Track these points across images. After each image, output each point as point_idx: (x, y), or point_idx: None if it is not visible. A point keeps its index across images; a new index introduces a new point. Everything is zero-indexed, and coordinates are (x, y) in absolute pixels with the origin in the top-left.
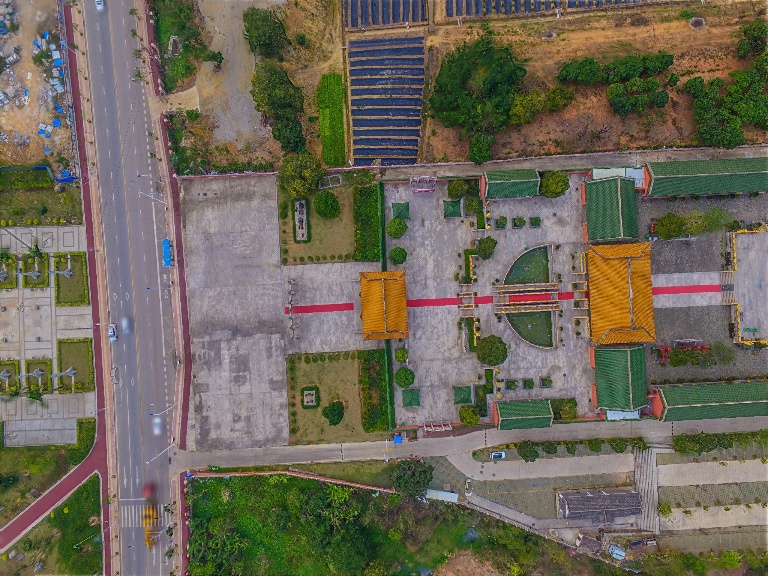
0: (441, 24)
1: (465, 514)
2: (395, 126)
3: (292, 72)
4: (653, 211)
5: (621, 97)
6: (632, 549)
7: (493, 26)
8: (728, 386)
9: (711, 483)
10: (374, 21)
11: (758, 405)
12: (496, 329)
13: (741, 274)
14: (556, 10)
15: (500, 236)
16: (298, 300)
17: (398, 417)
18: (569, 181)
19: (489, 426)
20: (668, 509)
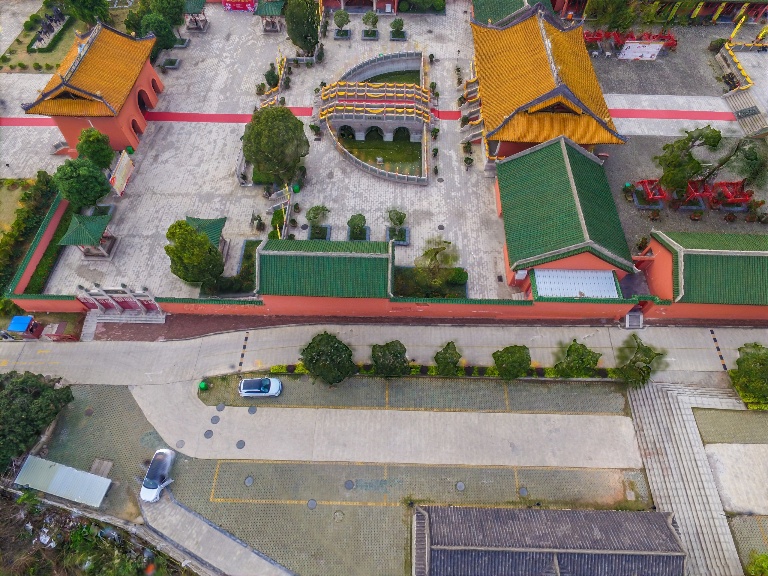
0: None
1: (126, 572)
2: None
3: None
4: None
5: None
6: None
7: None
8: None
9: None
10: None
11: None
12: None
13: (763, 94)
14: None
15: (341, 46)
16: None
17: (54, 288)
18: (453, 5)
19: (258, 322)
20: None
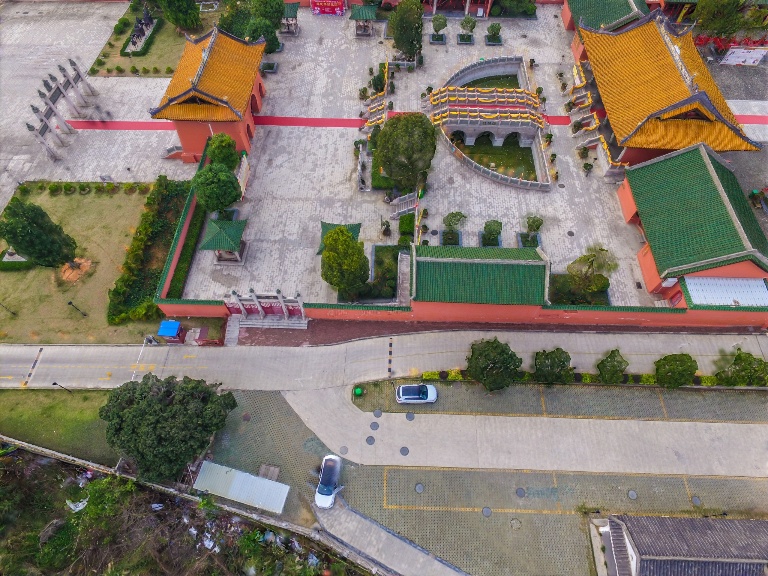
0: None
1: None
2: None
3: None
4: None
5: None
6: None
7: None
8: None
9: None
10: None
11: None
12: None
13: None
14: None
15: (438, 51)
16: (88, 114)
17: (191, 292)
18: (542, 9)
19: (400, 327)
20: None
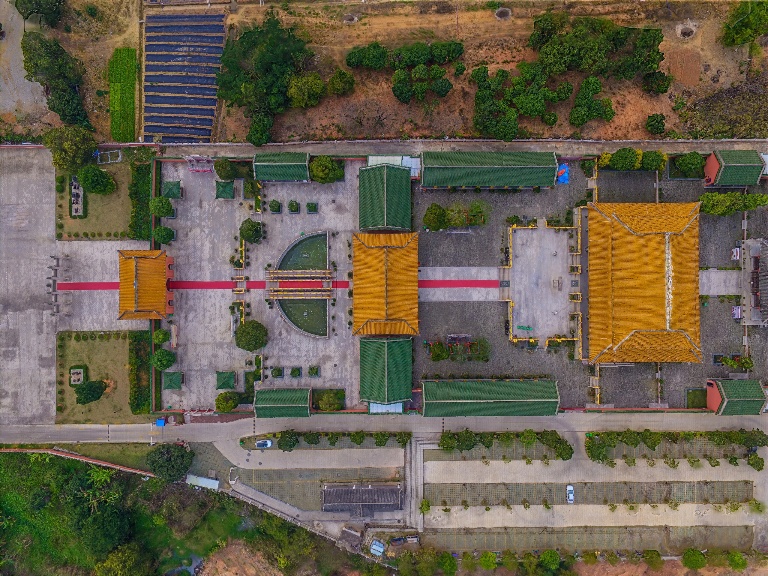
0: (243, 3)
1: (231, 502)
2: (189, 104)
3: (81, 44)
4: (433, 202)
5: (402, 84)
6: (393, 545)
7: (295, 7)
8: (493, 384)
9: (479, 482)
10: None
11: (520, 404)
12: (267, 315)
13: (518, 270)
14: None
15: (276, 220)
16: (71, 276)
17: (165, 400)
18: (350, 168)
19: None
20: (426, 506)
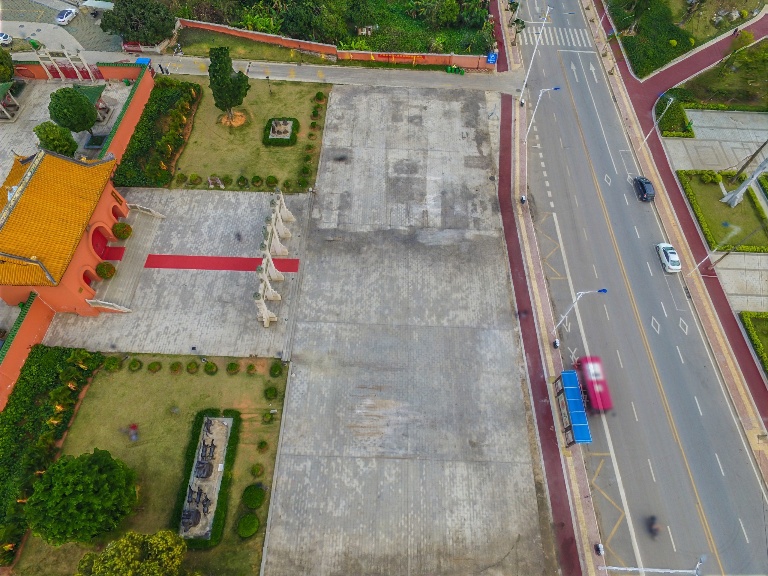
0: None
1: None
2: None
3: None
4: None
5: None
6: None
7: None
8: None
9: None
10: None
11: None
12: None
13: None
14: None
15: None
16: None
17: None
18: None
19: None
20: None
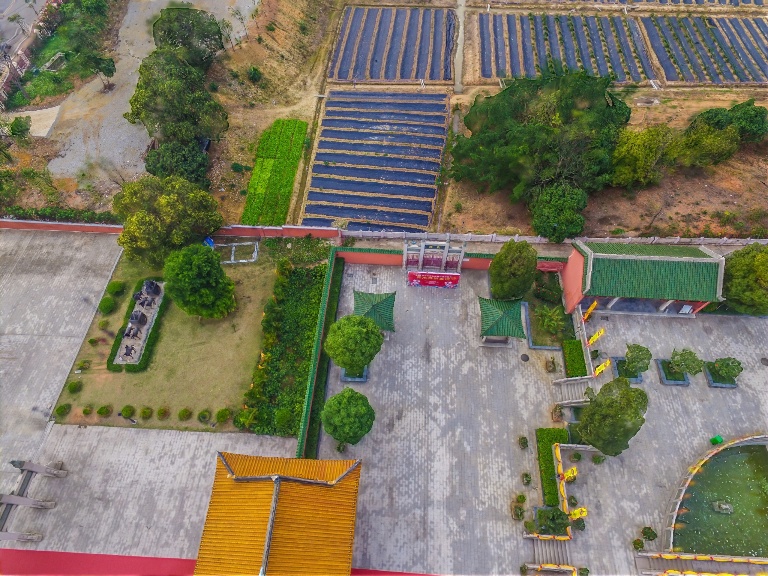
0: (473, 84)
1: None
2: (387, 193)
3: (227, 108)
4: None
5: None
6: None
7: None
8: None
9: None
10: (372, 75)
11: None
12: None
13: None
14: (650, 81)
15: None
16: (45, 530)
17: None
18: None
19: None
20: None
